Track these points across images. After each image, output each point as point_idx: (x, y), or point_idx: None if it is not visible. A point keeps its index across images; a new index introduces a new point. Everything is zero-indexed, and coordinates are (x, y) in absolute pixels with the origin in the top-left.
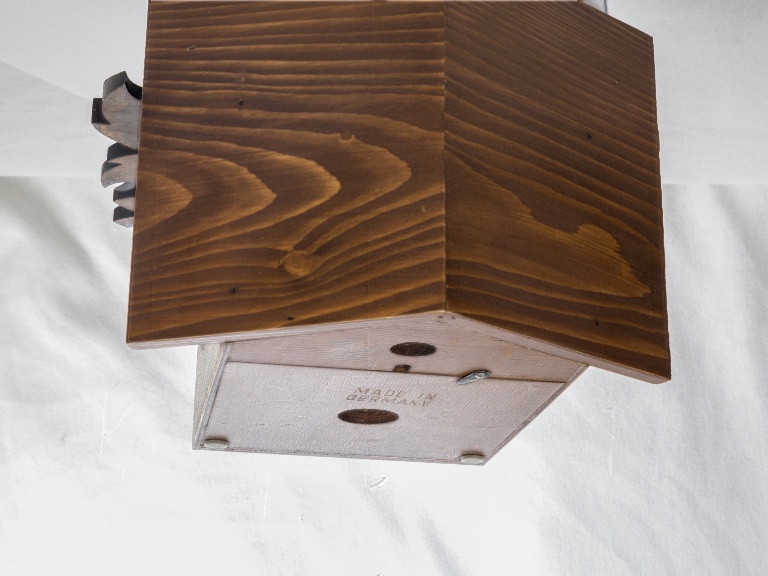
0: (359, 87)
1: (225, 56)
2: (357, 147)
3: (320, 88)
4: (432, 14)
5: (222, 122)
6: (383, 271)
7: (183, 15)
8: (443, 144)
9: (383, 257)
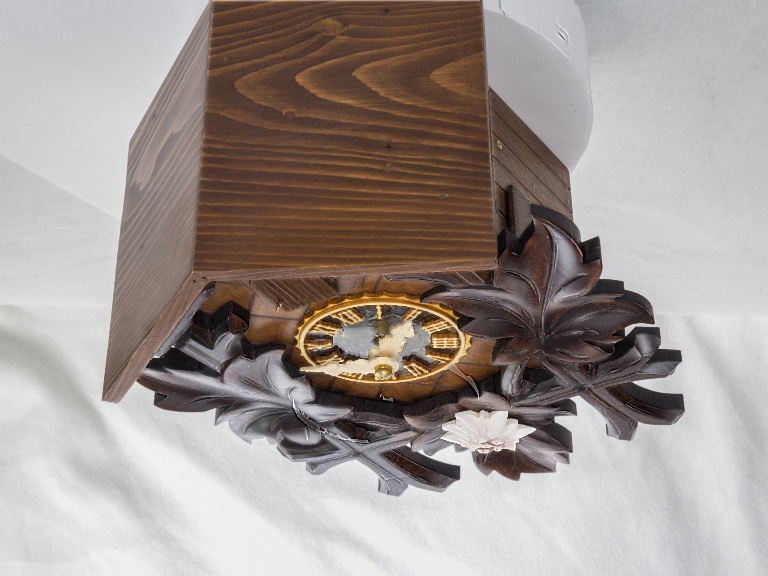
0: (278, 150)
1: (408, 186)
2: (280, 105)
3: (314, 152)
4: (209, 203)
5: (406, 132)
6: (260, 20)
7: (455, 226)
8: (206, 103)
9: (260, 29)
